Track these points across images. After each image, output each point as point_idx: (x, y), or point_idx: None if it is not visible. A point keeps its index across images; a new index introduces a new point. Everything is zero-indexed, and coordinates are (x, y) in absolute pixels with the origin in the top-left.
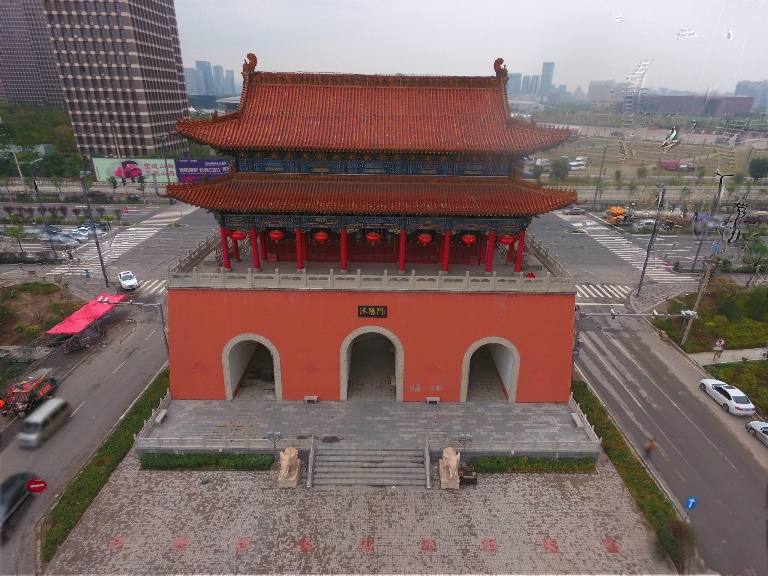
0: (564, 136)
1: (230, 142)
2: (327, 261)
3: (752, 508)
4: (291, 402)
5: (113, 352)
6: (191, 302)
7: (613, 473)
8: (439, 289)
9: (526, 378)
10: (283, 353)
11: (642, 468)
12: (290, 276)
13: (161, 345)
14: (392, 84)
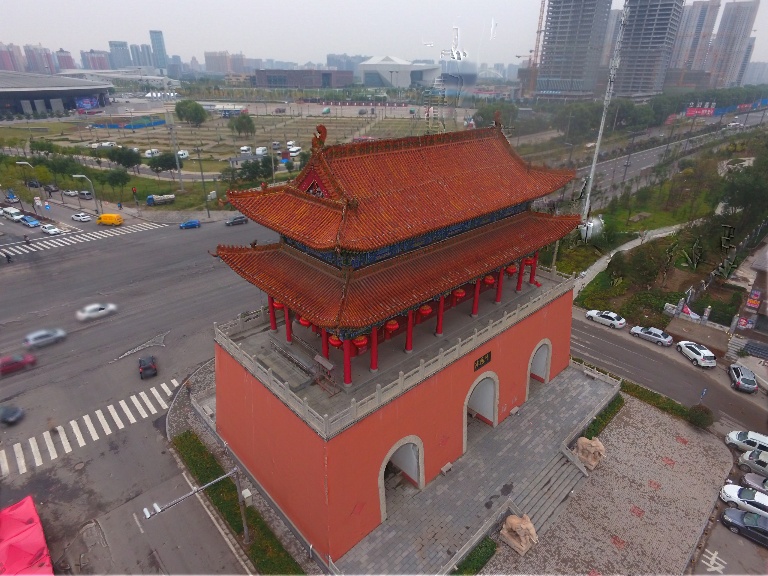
0: (573, 176)
1: (376, 242)
2: (404, 331)
3: (683, 379)
4: (434, 483)
5: None
6: (349, 441)
7: (630, 397)
8: (518, 319)
9: (553, 361)
10: (424, 440)
11: (638, 386)
12: (431, 362)
13: (179, 525)
14: (435, 143)
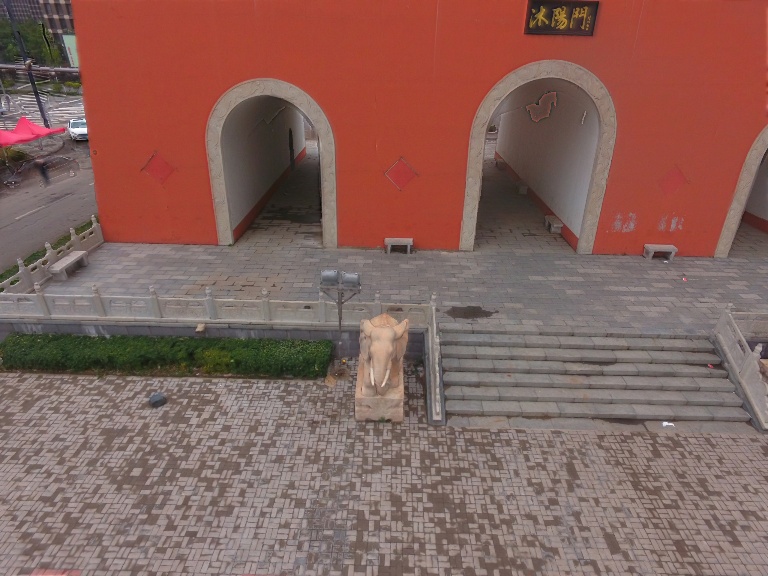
0: None
1: None
2: None
3: None
4: (356, 250)
5: (28, 196)
6: None
7: None
8: None
9: None
10: (342, 133)
11: None
12: None
13: None
14: None
